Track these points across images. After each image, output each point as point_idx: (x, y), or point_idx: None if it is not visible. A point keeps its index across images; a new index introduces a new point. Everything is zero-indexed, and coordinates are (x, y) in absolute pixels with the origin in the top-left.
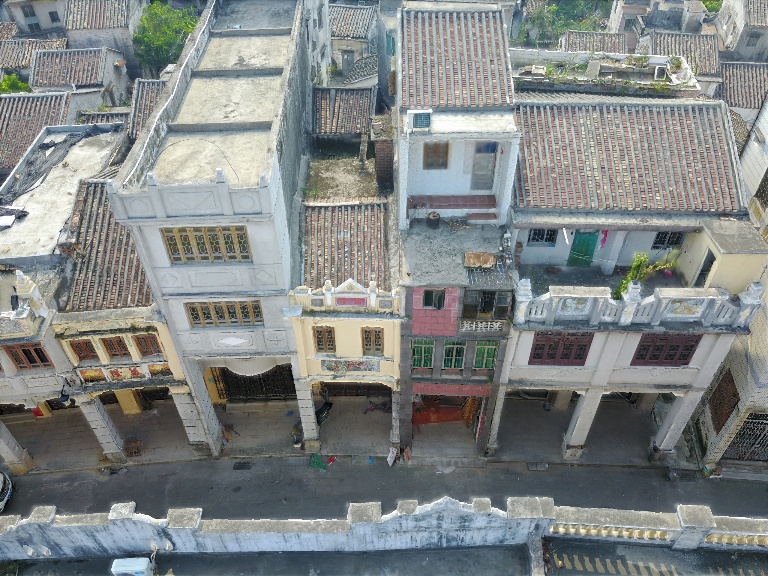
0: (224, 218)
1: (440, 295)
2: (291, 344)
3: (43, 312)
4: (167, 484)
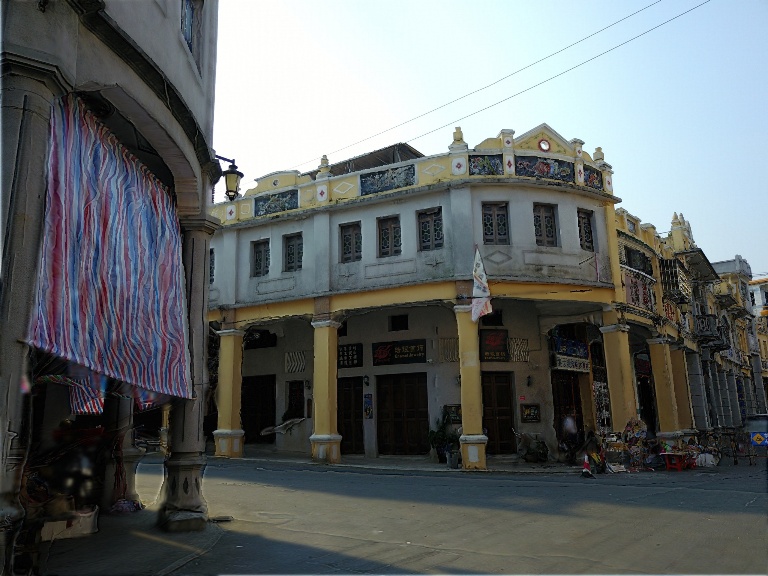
0: (748, 276)
1: None
2: (758, 347)
3: None
4: None
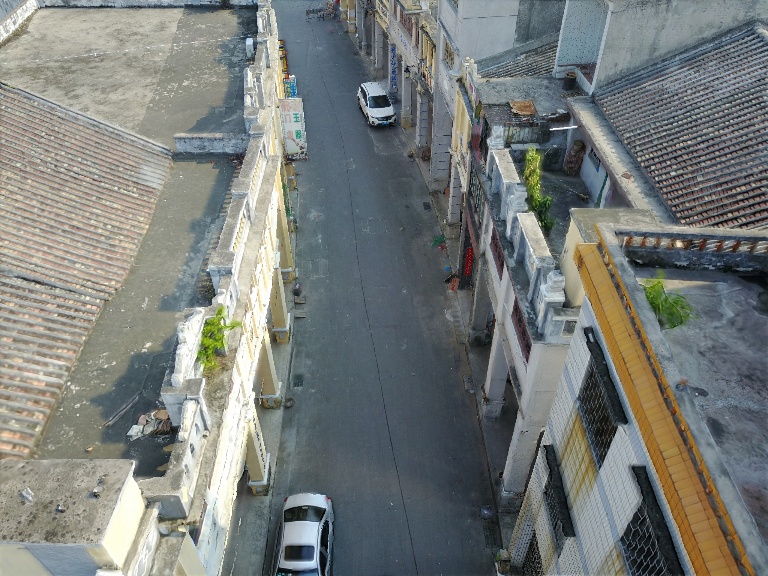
0: None
1: (479, 106)
2: None
3: (423, 5)
4: (406, 178)
